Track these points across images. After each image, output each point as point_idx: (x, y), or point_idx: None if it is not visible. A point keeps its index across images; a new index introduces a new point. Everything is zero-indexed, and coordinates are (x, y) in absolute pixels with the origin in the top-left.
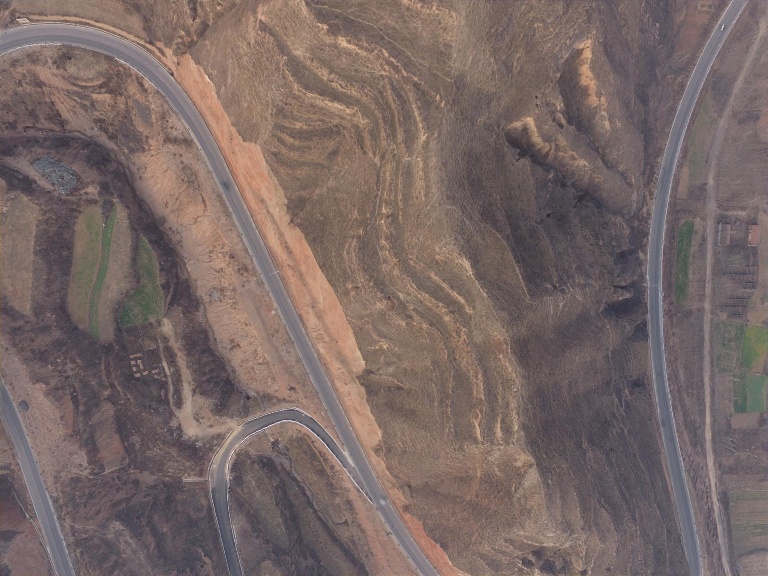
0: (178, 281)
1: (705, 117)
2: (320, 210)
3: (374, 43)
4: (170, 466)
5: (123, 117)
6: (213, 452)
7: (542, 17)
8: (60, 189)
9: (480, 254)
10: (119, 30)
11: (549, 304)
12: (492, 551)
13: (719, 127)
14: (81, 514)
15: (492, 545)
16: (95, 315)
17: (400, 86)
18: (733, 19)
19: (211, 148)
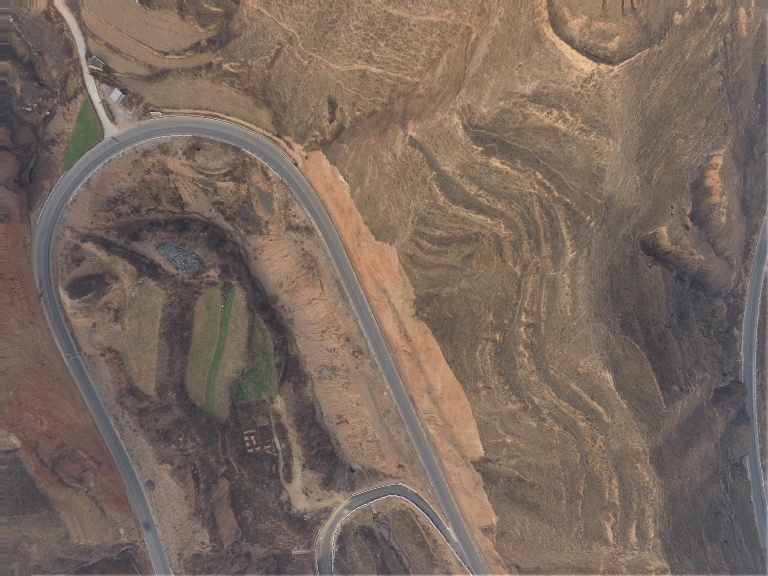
0: (288, 357)
1: None
2: (449, 308)
3: (529, 166)
4: (280, 539)
5: (243, 202)
6: (320, 525)
7: (685, 134)
8: (183, 273)
9: (620, 365)
10: (248, 123)
11: (679, 408)
12: None
13: None
14: None
15: None
16: (212, 393)
17: (549, 204)
18: None
19: (331, 236)
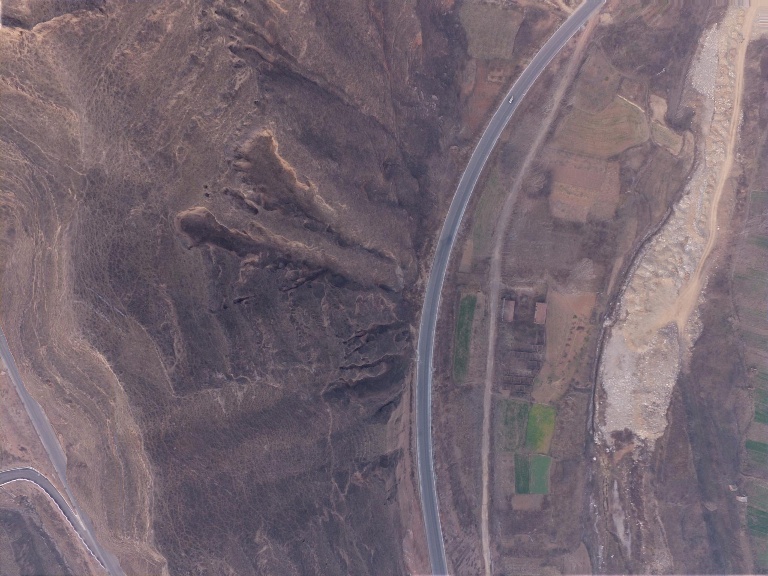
0: None
1: (493, 190)
2: (8, 284)
3: (3, 135)
4: None
5: None
6: None
7: (199, 110)
8: None
9: (122, 346)
10: None
11: (213, 396)
12: None
13: (507, 200)
14: None
15: None
16: None
17: (40, 176)
18: (523, 92)
19: None
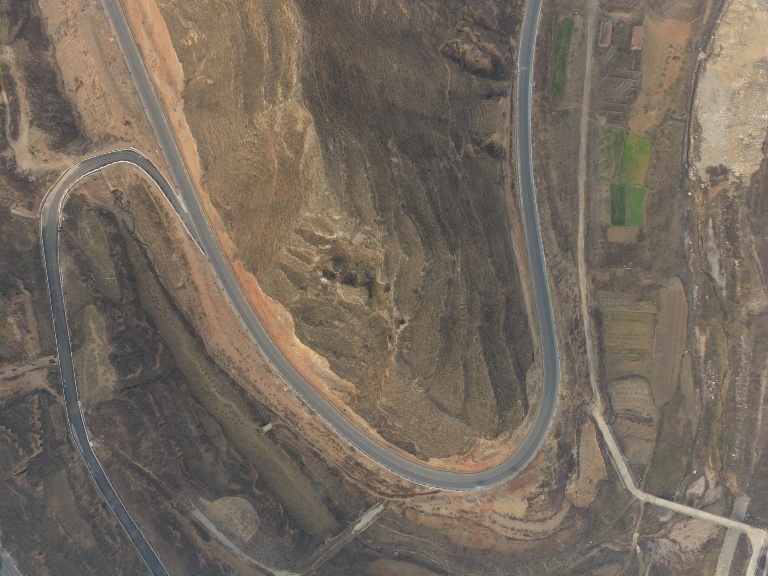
0: (29, 18)
1: None
2: None
3: None
4: None
5: None
6: (46, 188)
7: None
8: None
9: None
10: None
11: None
12: (289, 254)
13: None
14: None
15: (287, 245)
16: None
17: None
18: None
19: None
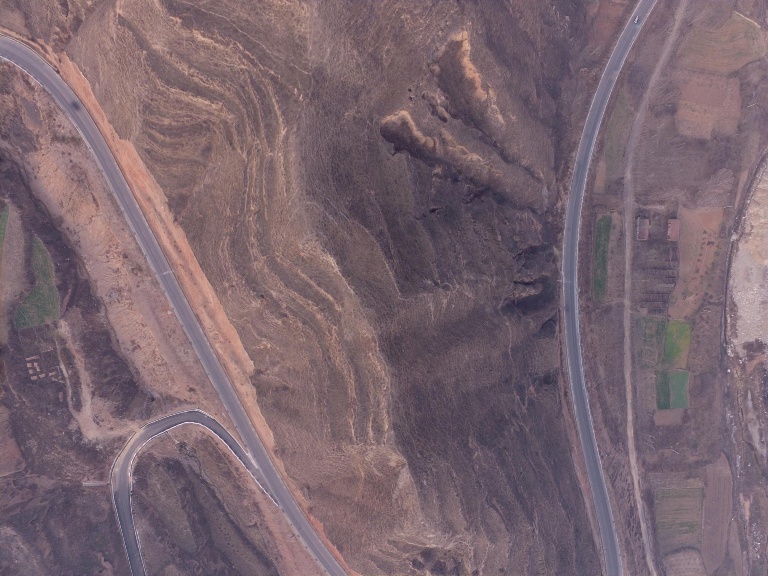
0: (77, 282)
1: (621, 111)
2: (199, 208)
3: (227, 36)
4: (69, 470)
5: (13, 116)
6: (114, 455)
7: (409, 8)
8: None
9: (348, 250)
10: (1, 27)
11: (427, 301)
12: (380, 553)
13: (636, 121)
14: None
15: (379, 547)
16: None
17: (259, 80)
18: (647, 11)
19: (100, 146)
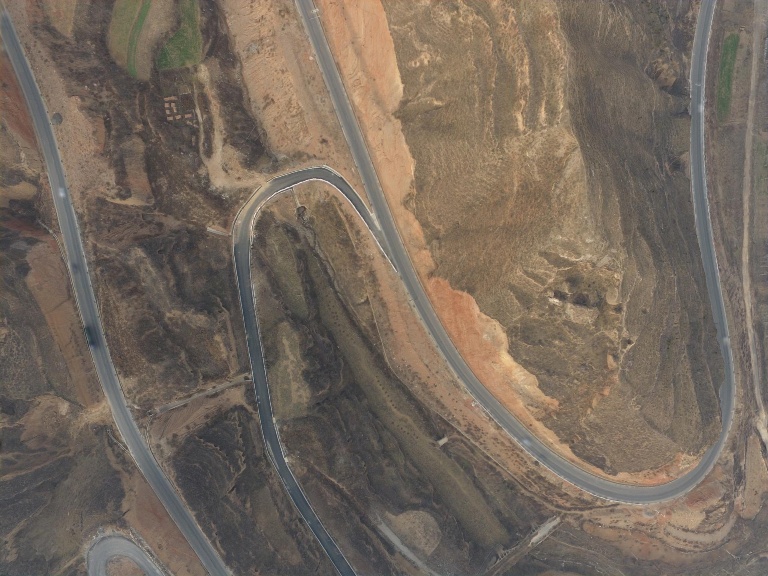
0: (217, 35)
1: None
2: None
3: None
4: (195, 212)
5: None
6: (239, 206)
7: None
8: None
9: None
10: None
11: (599, 7)
12: (524, 276)
13: None
14: (104, 236)
15: (525, 266)
16: (134, 53)
17: None
18: None
19: None
